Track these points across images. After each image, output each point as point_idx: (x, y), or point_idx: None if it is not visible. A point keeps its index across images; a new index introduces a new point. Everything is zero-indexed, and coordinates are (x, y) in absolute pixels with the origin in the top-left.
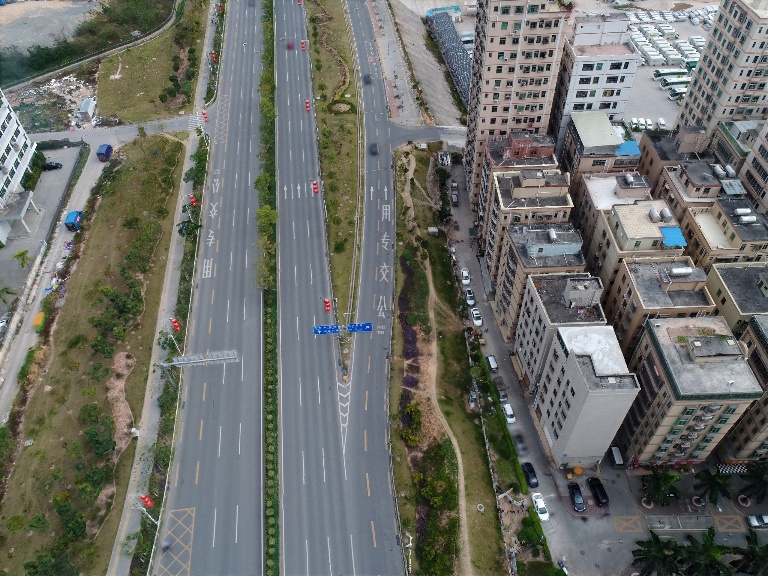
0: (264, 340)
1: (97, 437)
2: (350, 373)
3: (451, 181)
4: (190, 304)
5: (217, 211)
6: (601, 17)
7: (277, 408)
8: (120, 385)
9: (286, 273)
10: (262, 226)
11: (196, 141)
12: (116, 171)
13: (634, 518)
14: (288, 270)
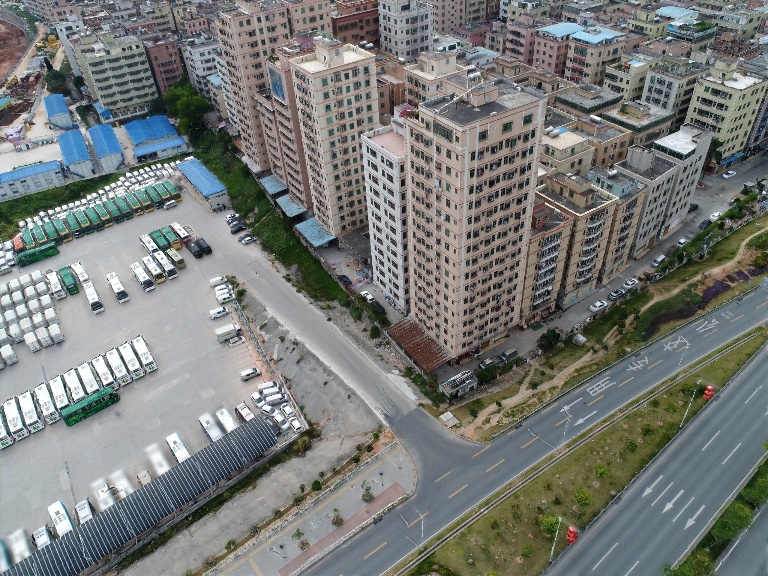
0: None
1: None
2: None
3: None
4: None
5: None
6: None
7: None
8: None
9: None
10: None
11: None
12: None
13: None
14: None
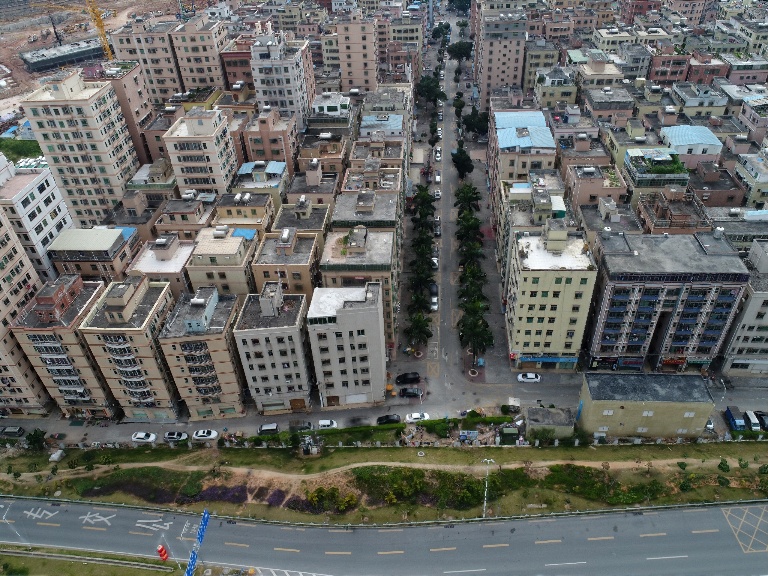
0: None
1: None
2: (243, 568)
3: None
4: None
5: None
6: None
7: None
8: None
9: None
10: None
11: None
12: None
13: (429, 365)
14: None
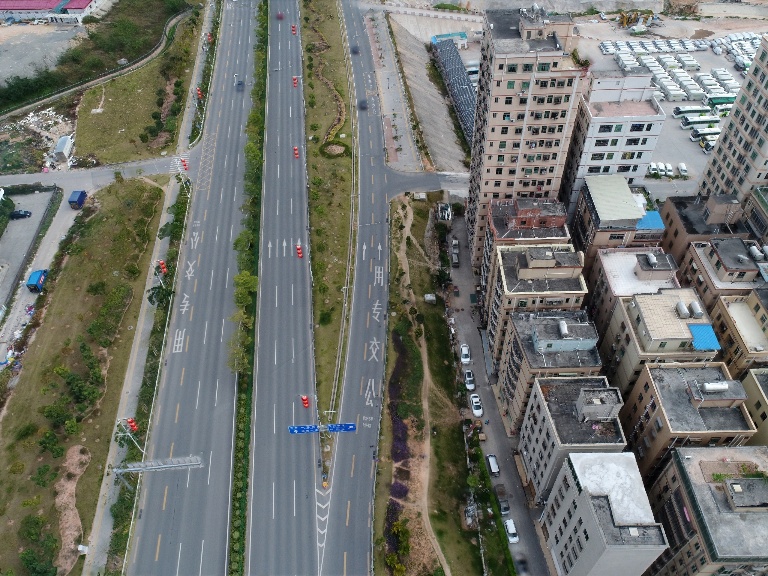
0: (236, 433)
1: (34, 564)
2: (331, 477)
3: (452, 237)
4: (156, 386)
5: (194, 271)
6: (621, 71)
7: (246, 522)
8: (70, 488)
9: (265, 349)
10: (239, 297)
11: (177, 187)
12: (88, 221)
13: None
14: (267, 345)
